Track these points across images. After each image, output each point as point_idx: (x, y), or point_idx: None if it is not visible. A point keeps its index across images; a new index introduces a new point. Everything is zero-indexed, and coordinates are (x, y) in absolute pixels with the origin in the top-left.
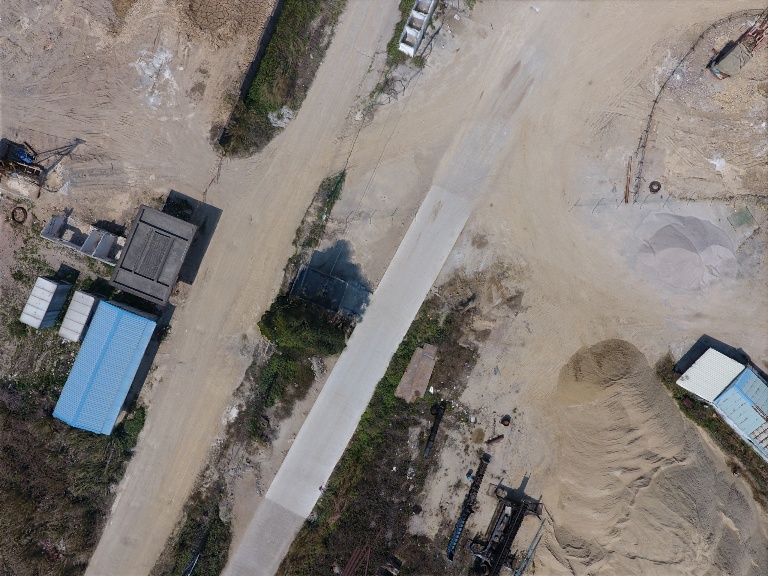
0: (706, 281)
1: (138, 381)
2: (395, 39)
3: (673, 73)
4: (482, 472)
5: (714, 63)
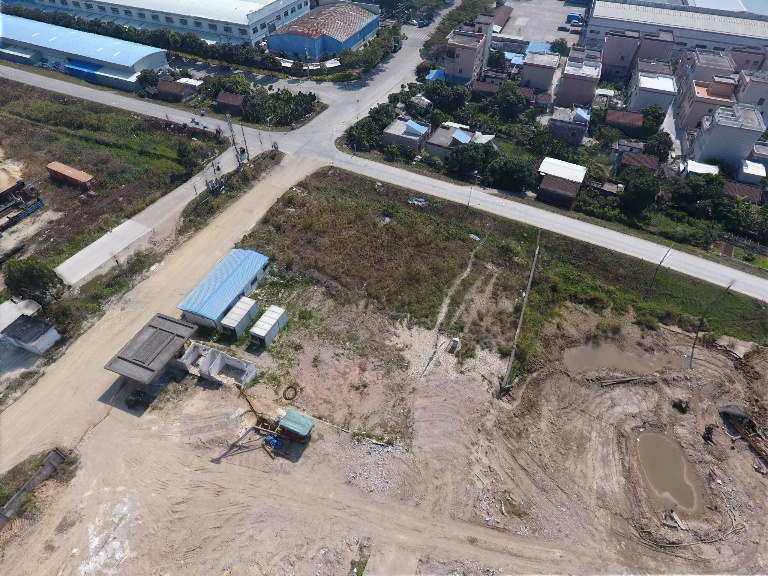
0: None
1: None
2: None
3: None
4: None
5: None
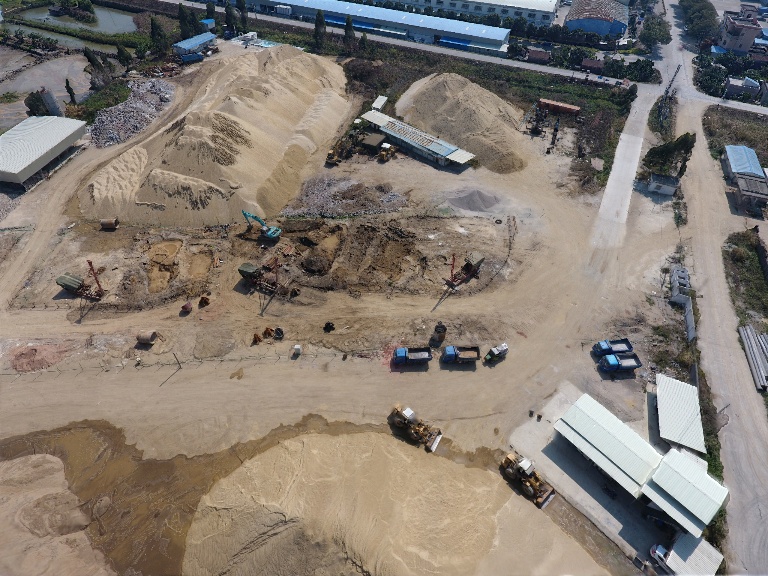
0: None
1: None
2: None
3: (502, 268)
4: (554, 139)
5: None
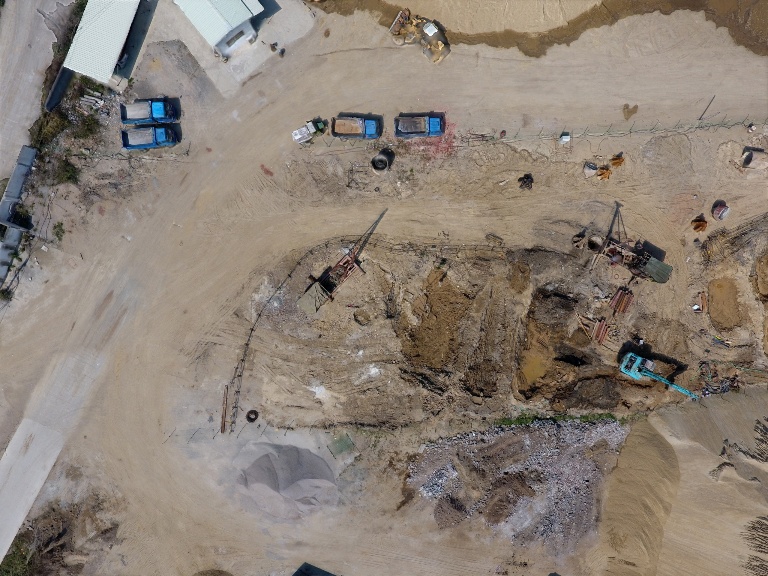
0: (305, 510)
1: None
2: None
3: (269, 301)
4: None
5: None
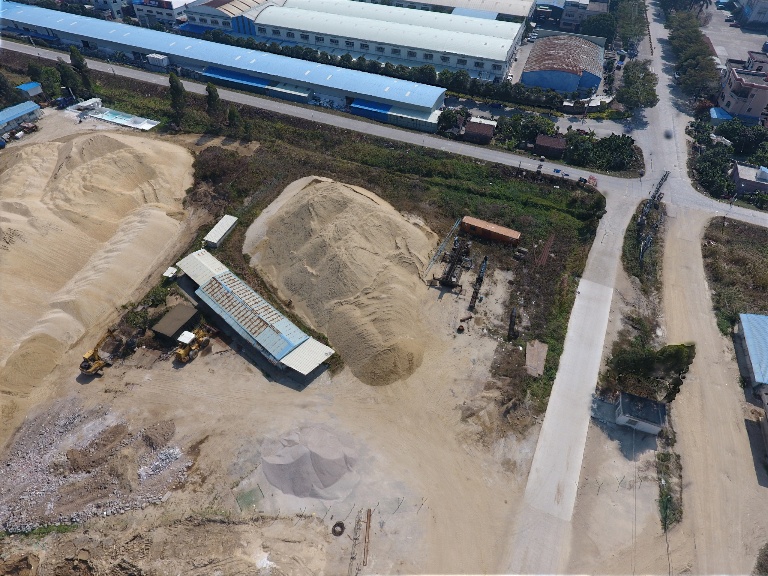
0: (294, 435)
1: (740, 351)
2: None
3: None
4: (474, 300)
5: None
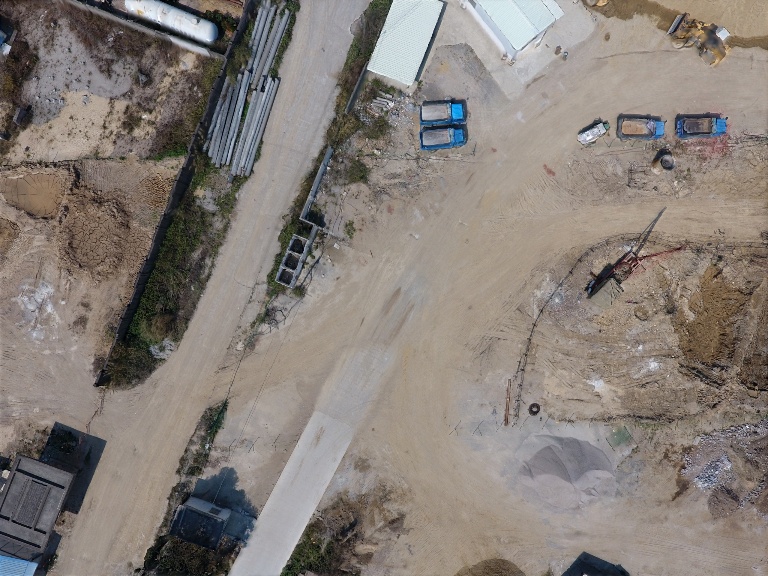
0: (585, 501)
1: None
2: (274, 272)
3: (551, 297)
4: None
5: (590, 290)
